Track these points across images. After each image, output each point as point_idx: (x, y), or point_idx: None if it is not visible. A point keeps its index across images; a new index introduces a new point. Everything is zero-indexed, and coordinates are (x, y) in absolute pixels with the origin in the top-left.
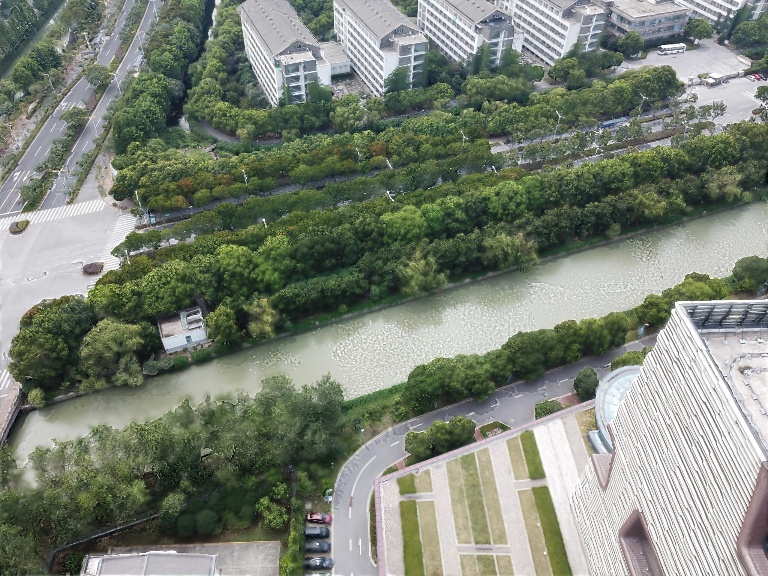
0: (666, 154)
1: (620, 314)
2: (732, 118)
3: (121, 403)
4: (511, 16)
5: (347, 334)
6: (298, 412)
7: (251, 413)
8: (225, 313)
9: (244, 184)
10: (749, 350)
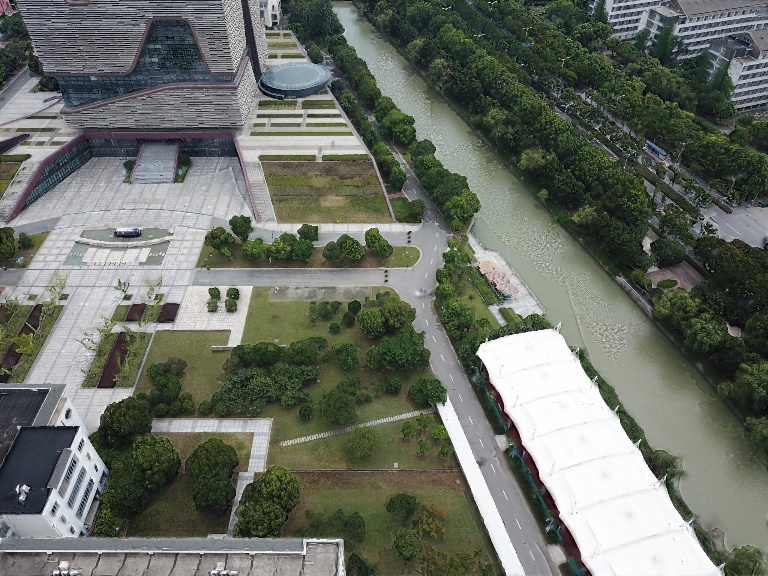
0: (555, 121)
1: (377, 89)
2: (726, 238)
3: (354, 14)
4: (761, 49)
5: (390, 52)
6: None
7: None
8: (381, 3)
9: (491, 8)
10: None
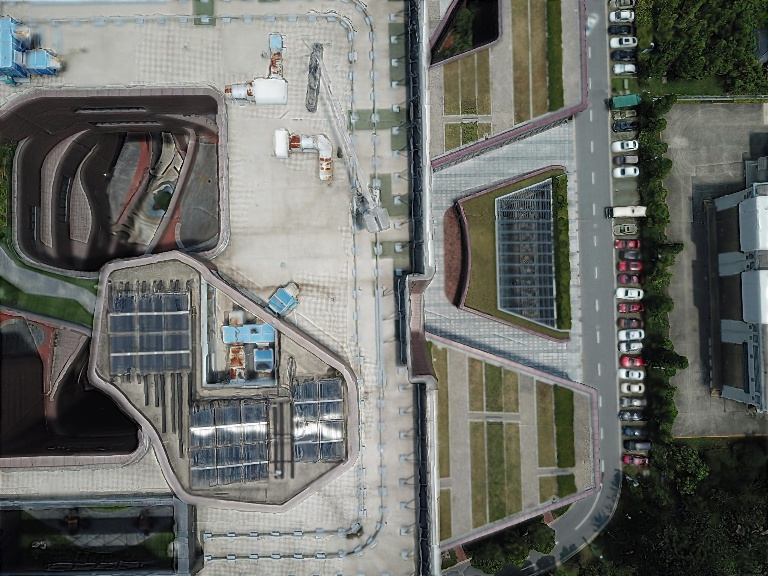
0: None
1: None
2: None
3: None
4: None
5: None
6: (702, 571)
7: (758, 568)
8: None
9: None
10: (337, 565)
